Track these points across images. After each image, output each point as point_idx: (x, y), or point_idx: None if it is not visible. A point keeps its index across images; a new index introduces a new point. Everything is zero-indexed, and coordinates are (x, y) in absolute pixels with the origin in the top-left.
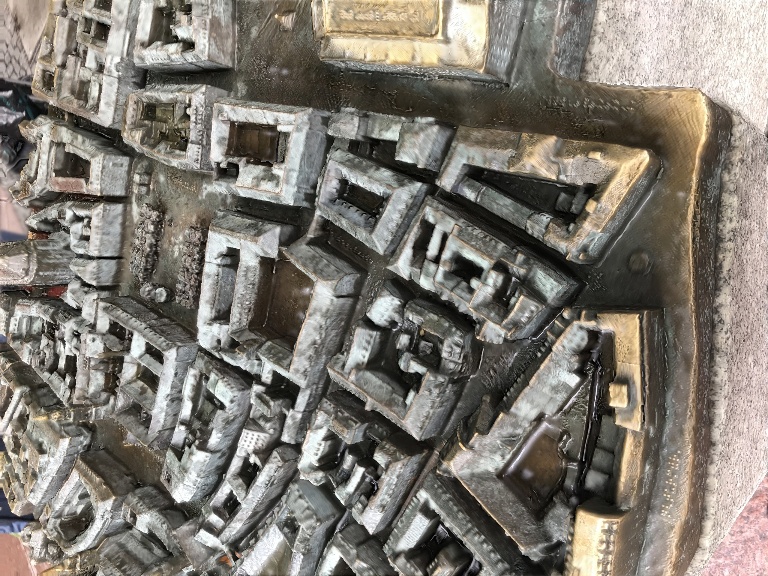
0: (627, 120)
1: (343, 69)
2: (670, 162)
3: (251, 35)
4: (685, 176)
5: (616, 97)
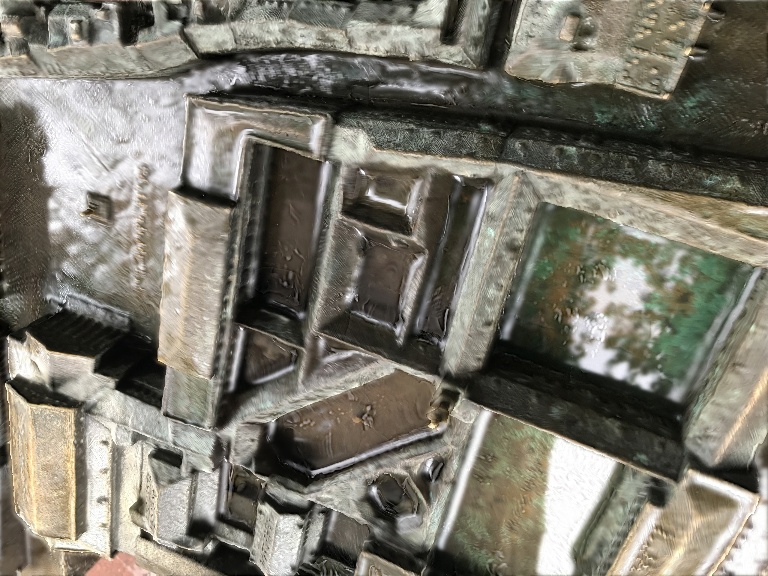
0: (46, 552)
1: (52, 304)
2: (30, 566)
3: (81, 119)
4: (24, 571)
5: (57, 552)
